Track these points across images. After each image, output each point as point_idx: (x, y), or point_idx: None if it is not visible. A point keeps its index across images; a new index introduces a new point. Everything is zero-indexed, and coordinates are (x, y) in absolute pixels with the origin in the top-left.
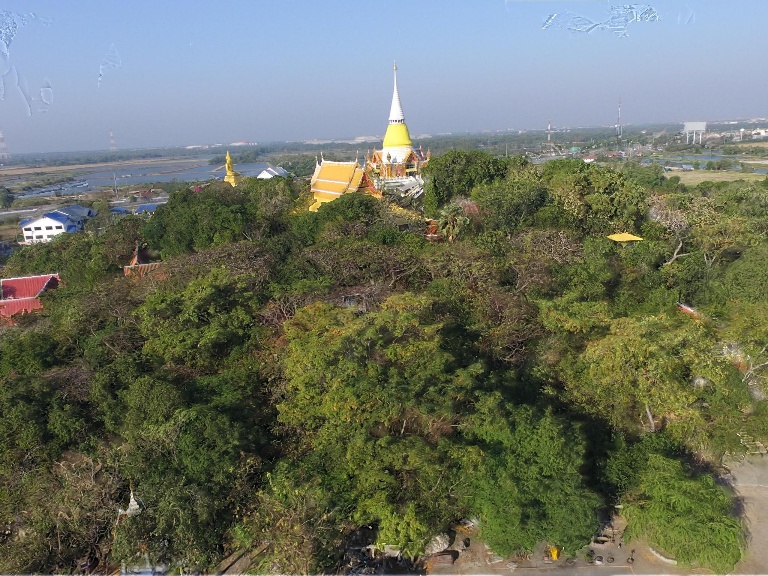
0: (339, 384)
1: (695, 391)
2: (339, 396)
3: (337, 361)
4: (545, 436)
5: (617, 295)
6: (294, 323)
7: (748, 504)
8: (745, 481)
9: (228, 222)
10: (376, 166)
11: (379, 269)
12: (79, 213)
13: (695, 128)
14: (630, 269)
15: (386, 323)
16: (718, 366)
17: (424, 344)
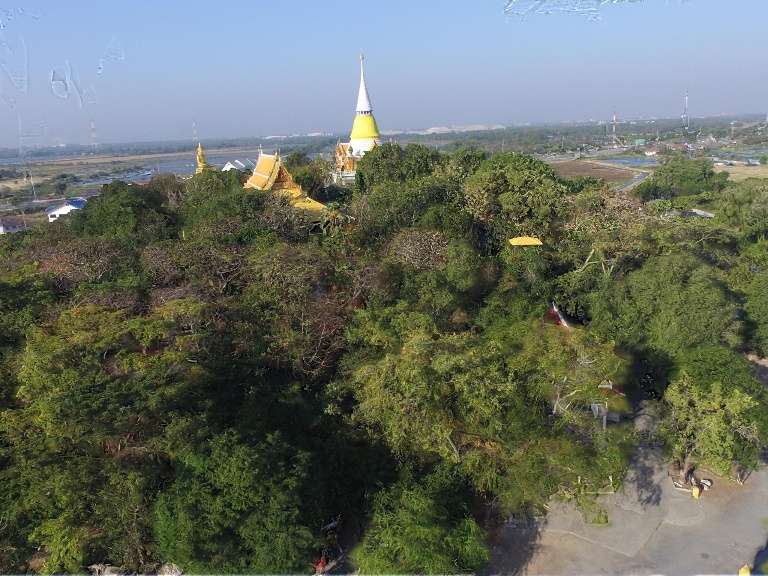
0: (53, 394)
1: (472, 422)
2: (48, 407)
3: (59, 369)
4: (233, 466)
5: (482, 306)
6: (45, 326)
7: (540, 554)
8: (555, 526)
9: (125, 216)
10: (342, 159)
11: (201, 270)
12: None
13: None
14: (507, 277)
15: (132, 330)
16: (497, 395)
17: (167, 355)
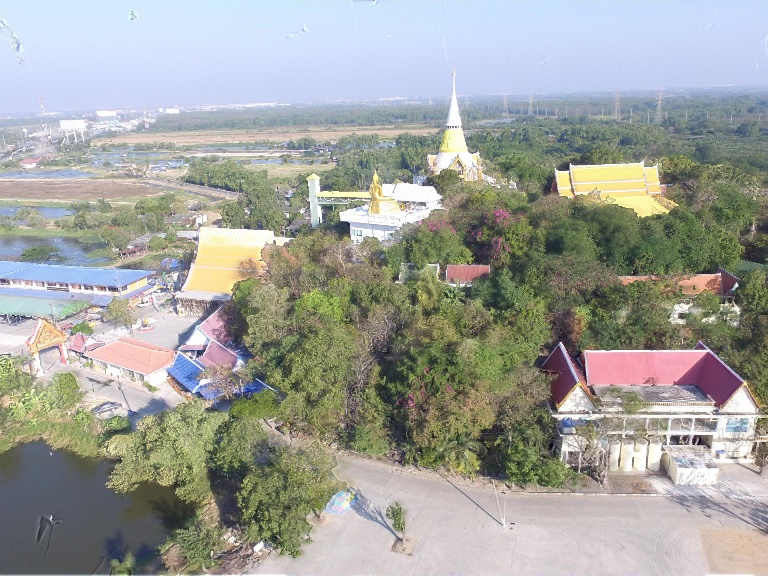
0: None
1: None
2: None
3: None
4: None
5: None
6: None
7: None
8: None
9: None
10: None
11: None
12: None
13: (74, 126)
14: None
15: None
16: None
17: None
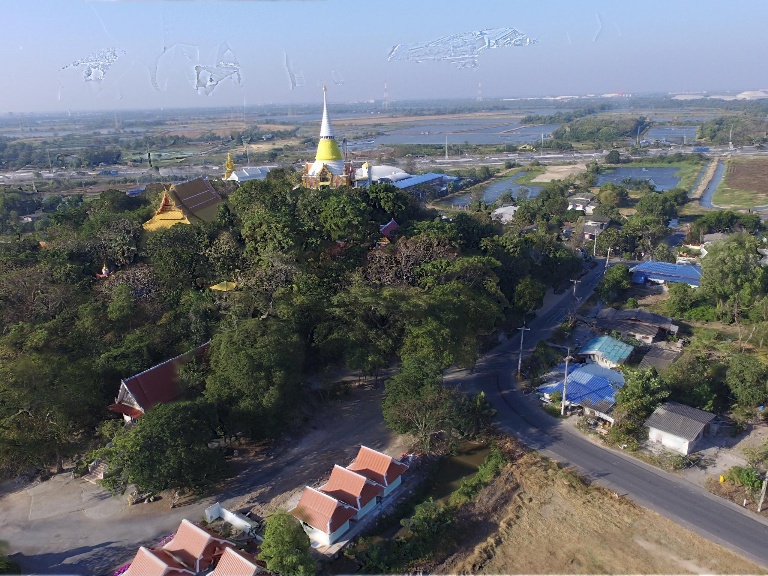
0: None
1: None
2: None
3: None
4: None
5: (133, 332)
6: None
7: None
8: (33, 490)
9: None
10: None
11: None
12: None
13: None
14: (165, 314)
15: None
16: None
17: None
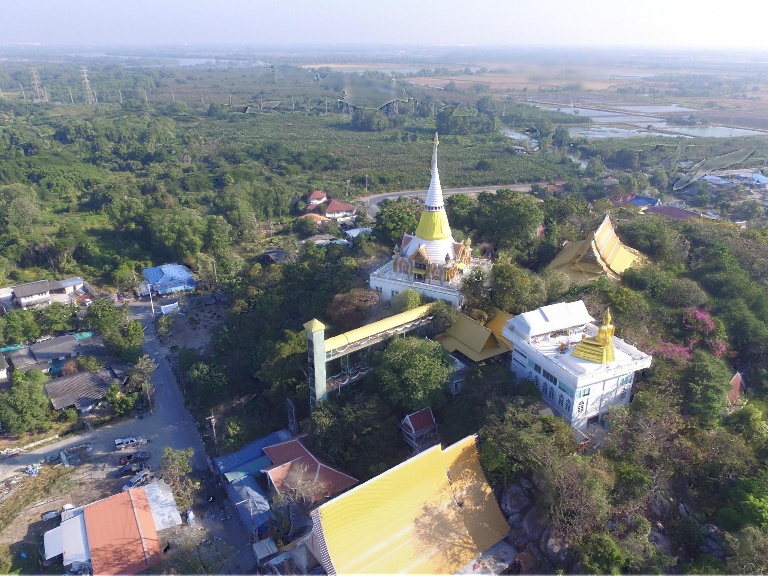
0: None
1: None
2: None
3: None
4: None
5: None
6: None
7: None
8: None
9: None
10: (458, 262)
11: None
12: None
13: None
14: None
15: None
16: None
17: None
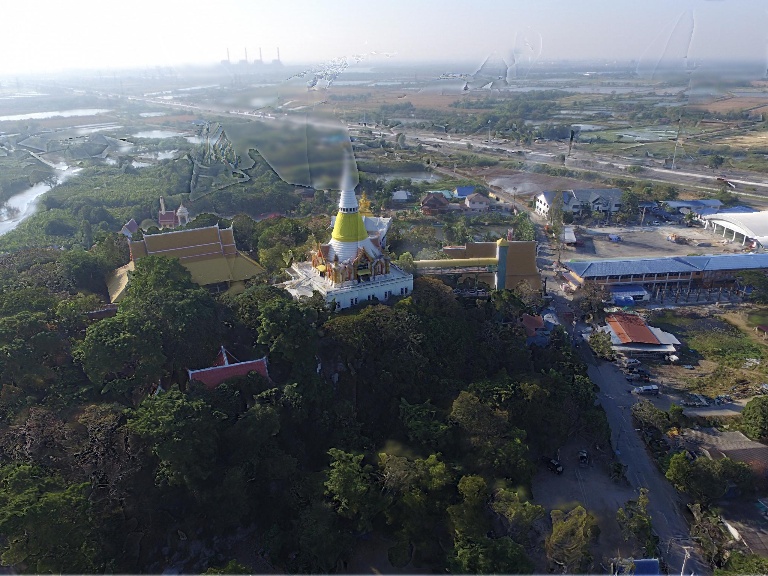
0: None
1: None
2: None
3: None
4: None
5: None
6: None
7: None
8: None
9: None
10: None
11: None
12: (591, 198)
13: None
14: None
15: None
16: None
17: None
